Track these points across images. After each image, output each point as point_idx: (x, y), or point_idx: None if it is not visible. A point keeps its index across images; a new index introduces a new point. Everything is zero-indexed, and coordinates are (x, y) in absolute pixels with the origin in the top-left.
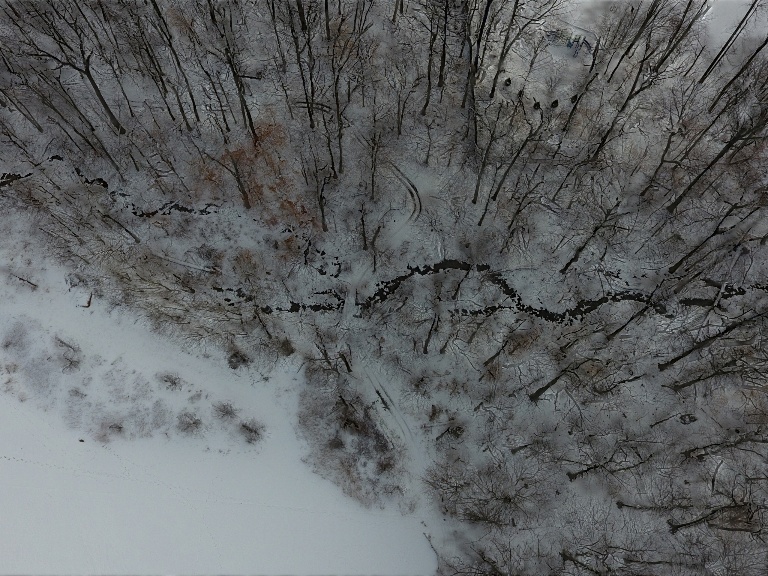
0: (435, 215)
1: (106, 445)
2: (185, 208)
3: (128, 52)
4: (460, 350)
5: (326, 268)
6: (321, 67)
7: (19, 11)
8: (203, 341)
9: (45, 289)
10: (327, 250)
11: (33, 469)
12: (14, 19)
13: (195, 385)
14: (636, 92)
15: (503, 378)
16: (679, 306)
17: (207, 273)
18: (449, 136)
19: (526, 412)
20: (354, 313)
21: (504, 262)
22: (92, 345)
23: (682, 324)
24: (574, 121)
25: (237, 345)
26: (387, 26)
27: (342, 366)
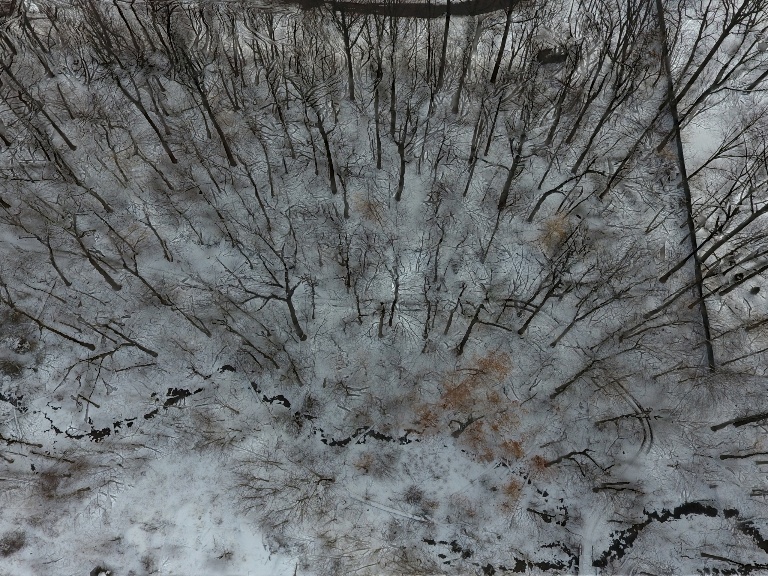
0: (670, 446)
1: None
2: (382, 435)
3: (310, 246)
4: None
5: (551, 514)
6: None
7: (173, 183)
8: None
9: (241, 557)
10: (550, 491)
11: None
12: None
13: None
14: None
15: None
16: None
17: (416, 522)
18: (677, 344)
19: None
20: None
21: (757, 509)
22: None
23: None
24: None
25: None
26: (594, 204)
27: None
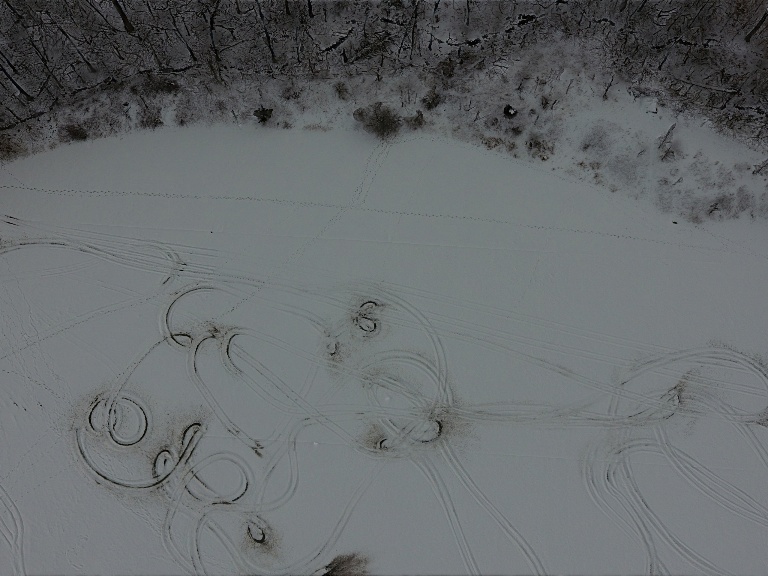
0: None
1: (698, 226)
2: (689, 42)
3: None
4: None
5: None
6: None
7: None
8: (762, 141)
9: (614, 99)
10: None
11: (643, 244)
12: None
13: None
14: None
15: None
16: None
17: (728, 94)
18: None
19: None
20: None
21: None
22: (671, 143)
23: None
24: None
25: None
26: None
27: None
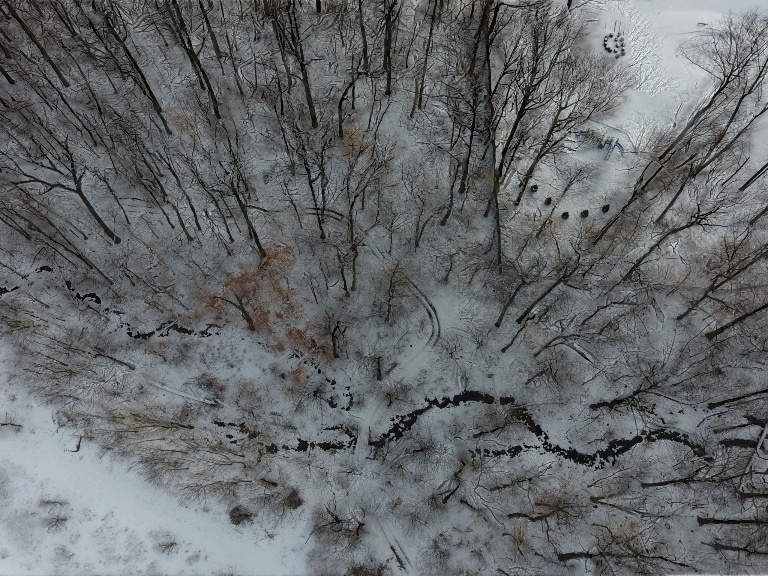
0: (455, 340)
1: None
2: (184, 329)
3: (124, 155)
4: (482, 500)
5: (337, 400)
6: (333, 169)
7: (7, 101)
8: (202, 492)
9: (30, 430)
10: (338, 379)
11: None
12: (2, 110)
13: (193, 545)
14: (681, 228)
15: (529, 533)
16: (719, 448)
17: (207, 405)
18: (470, 249)
19: (554, 574)
20: (367, 455)
21: (530, 396)
22: (81, 497)
23: (723, 470)
24: (606, 237)
25: (239, 496)
26: (404, 123)
27: (354, 525)
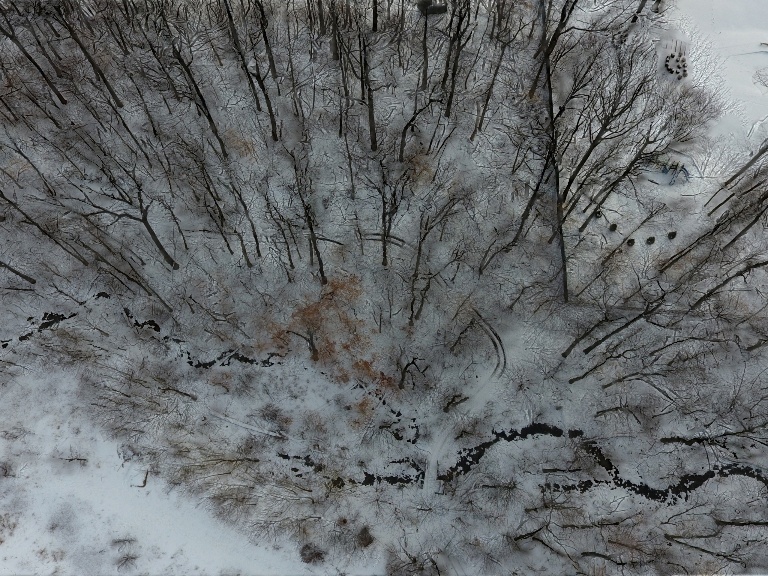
0: (521, 371)
1: None
2: (246, 358)
3: (183, 179)
4: (555, 538)
5: (403, 432)
6: None
7: (60, 122)
8: (272, 529)
9: (95, 464)
10: (403, 411)
11: None
12: (55, 132)
13: None
14: (764, 263)
15: None
16: None
17: (272, 438)
18: (535, 277)
19: None
20: (436, 490)
21: (599, 429)
22: (149, 534)
23: None
24: (675, 266)
25: (309, 533)
26: (464, 146)
27: (428, 564)
